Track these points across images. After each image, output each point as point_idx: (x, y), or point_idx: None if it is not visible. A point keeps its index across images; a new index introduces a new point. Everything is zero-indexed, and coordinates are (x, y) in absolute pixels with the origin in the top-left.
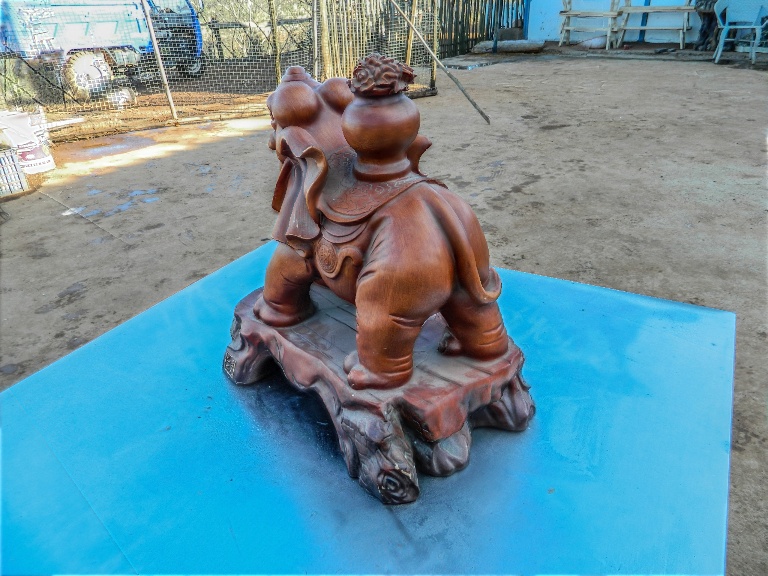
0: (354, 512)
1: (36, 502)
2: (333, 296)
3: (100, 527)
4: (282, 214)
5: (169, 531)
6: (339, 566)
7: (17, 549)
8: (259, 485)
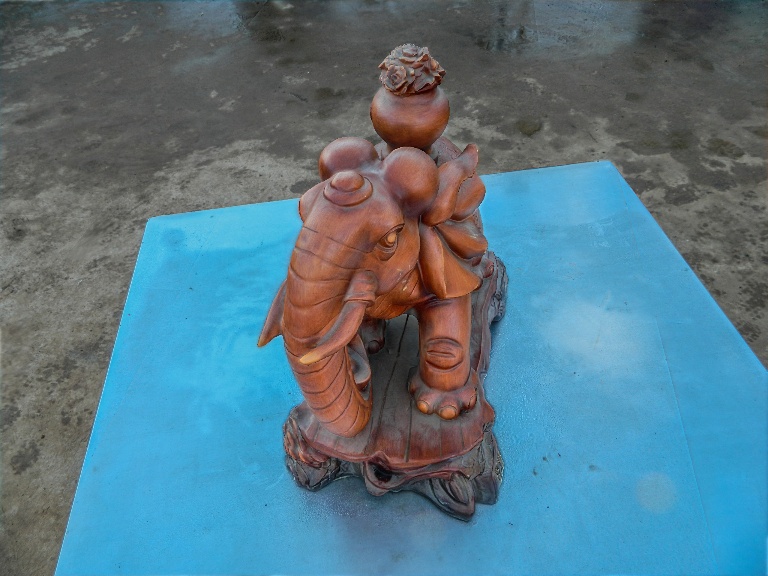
0: (524, 296)
1: (733, 483)
2: (383, 373)
3: (683, 412)
4: (461, 267)
5: (636, 371)
6: (557, 283)
7: (750, 445)
8: (561, 353)
